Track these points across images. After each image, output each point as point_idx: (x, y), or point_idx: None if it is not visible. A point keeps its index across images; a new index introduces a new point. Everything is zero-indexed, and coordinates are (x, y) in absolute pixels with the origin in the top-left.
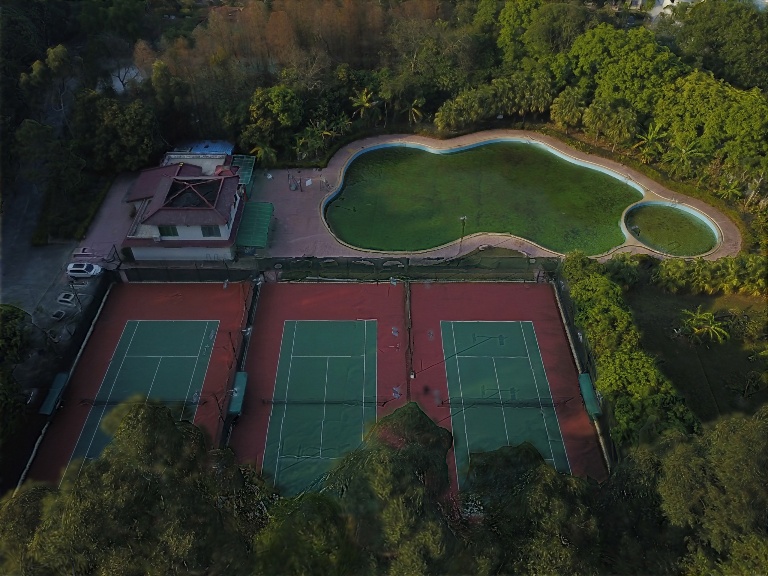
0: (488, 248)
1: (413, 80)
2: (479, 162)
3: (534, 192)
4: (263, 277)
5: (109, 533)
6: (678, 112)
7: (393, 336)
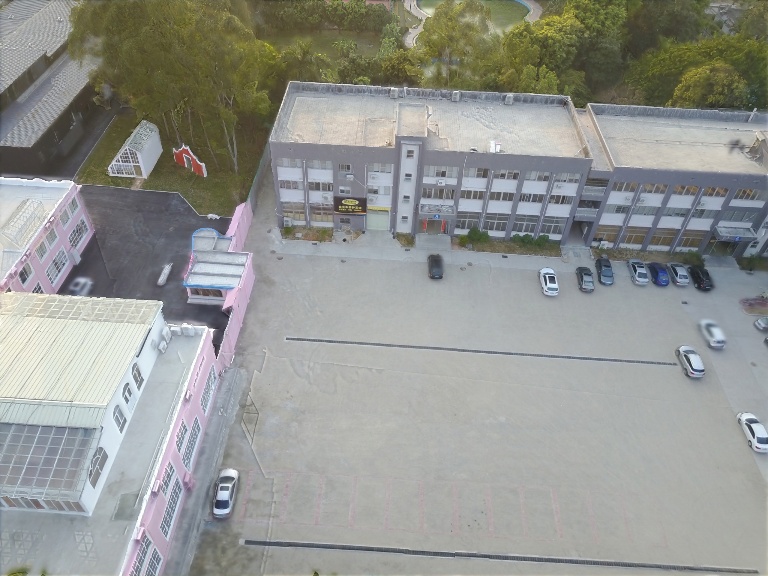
0: (420, 20)
1: None
2: None
3: None
4: None
5: None
6: None
7: None
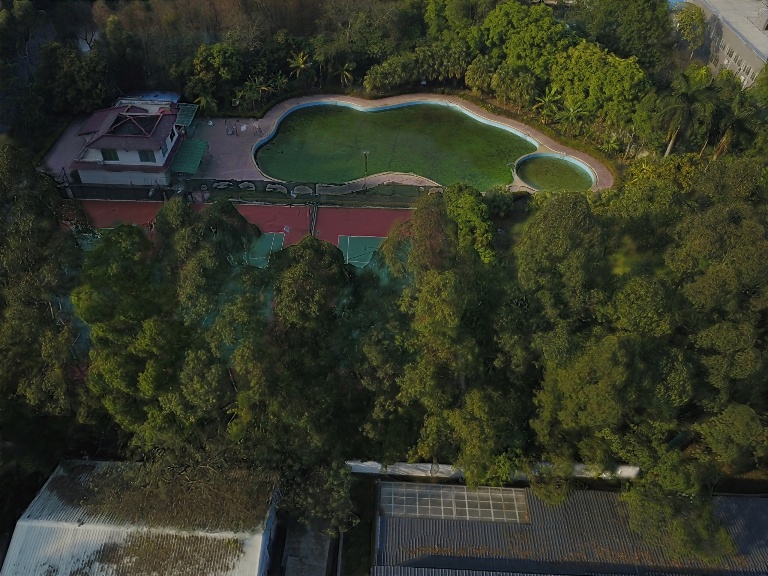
0: None
1: (345, 46)
2: (400, 119)
3: (443, 144)
4: (191, 198)
5: None
6: (568, 77)
7: (285, 232)
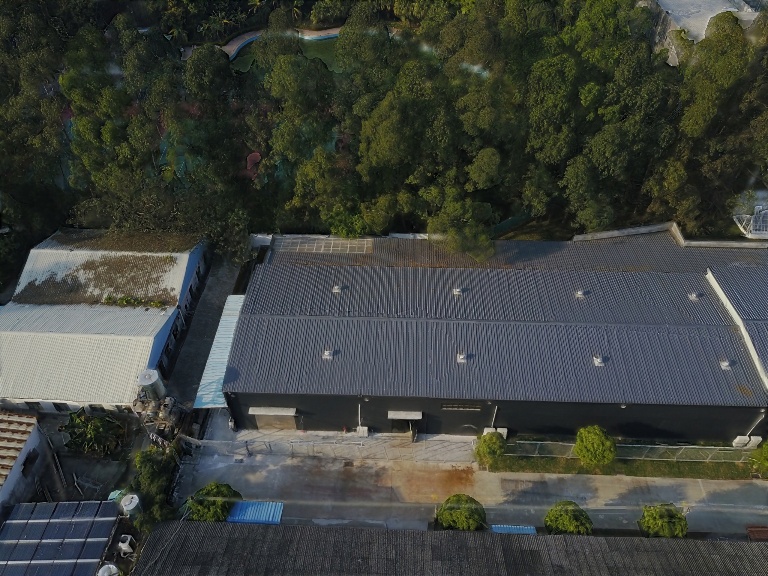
0: None
1: None
2: None
3: None
4: None
5: (1, 10)
6: (473, 0)
7: None
